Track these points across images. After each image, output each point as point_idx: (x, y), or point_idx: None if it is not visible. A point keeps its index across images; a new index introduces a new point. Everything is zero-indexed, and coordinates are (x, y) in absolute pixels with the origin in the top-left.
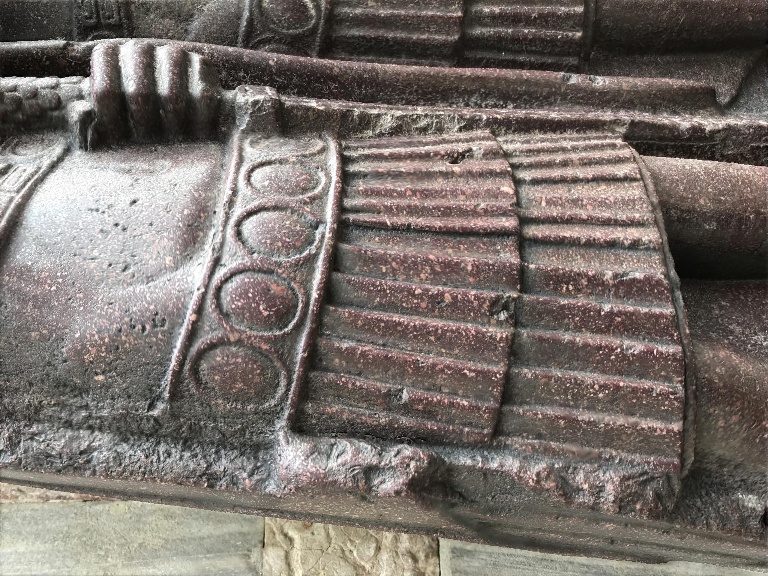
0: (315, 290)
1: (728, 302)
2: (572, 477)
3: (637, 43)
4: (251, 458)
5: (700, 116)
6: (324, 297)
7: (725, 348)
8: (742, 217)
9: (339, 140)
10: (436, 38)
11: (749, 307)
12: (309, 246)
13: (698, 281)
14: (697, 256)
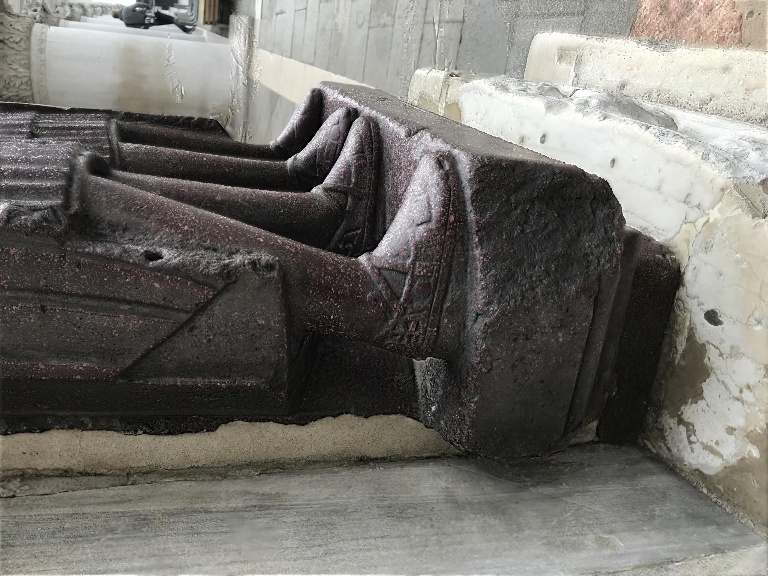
0: None
1: None
2: None
3: None
4: None
5: None
6: None
7: None
8: (179, 190)
9: None
10: None
11: None
12: None
13: None
14: None
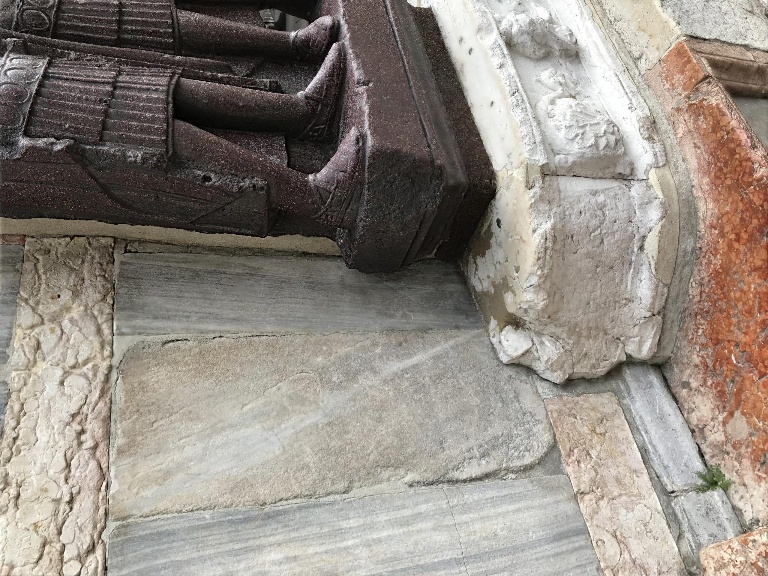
0: (34, 91)
1: (223, 136)
2: (127, 152)
3: (202, 48)
4: (10, 148)
5: None
6: (38, 94)
7: None
8: (218, 99)
9: (52, 59)
10: (106, 37)
11: (232, 139)
12: (33, 79)
13: (212, 129)
14: (204, 114)
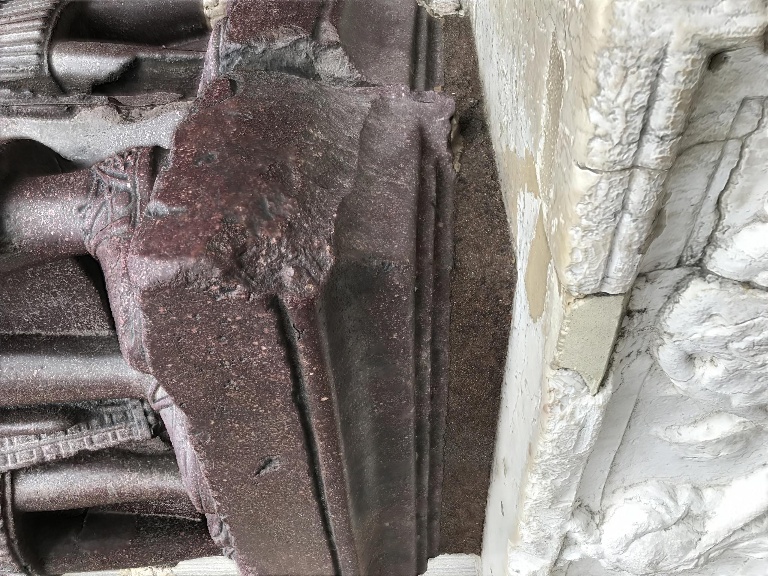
0: None
1: None
2: None
3: None
4: None
5: (66, 436)
6: None
7: (63, 563)
8: None
9: None
10: None
11: None
12: None
13: None
14: None
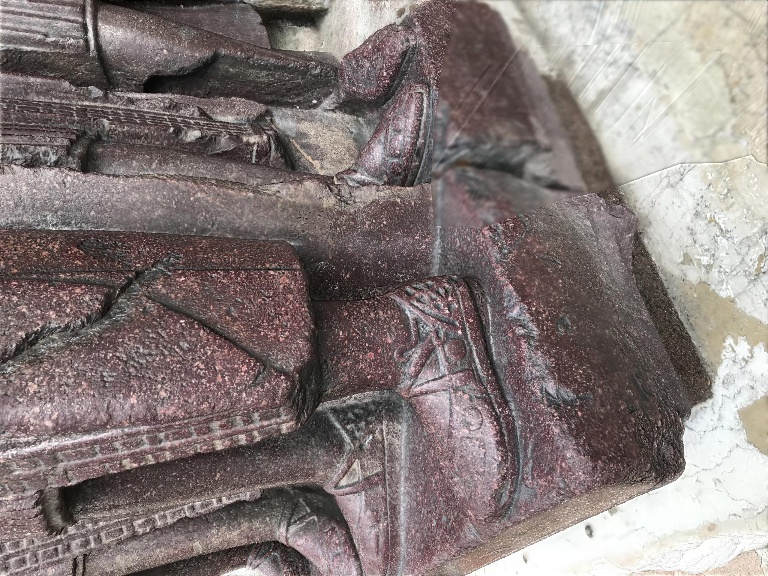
0: None
1: None
2: None
3: None
4: None
5: None
6: None
7: None
8: None
9: None
10: None
11: None
12: None
13: None
14: None
